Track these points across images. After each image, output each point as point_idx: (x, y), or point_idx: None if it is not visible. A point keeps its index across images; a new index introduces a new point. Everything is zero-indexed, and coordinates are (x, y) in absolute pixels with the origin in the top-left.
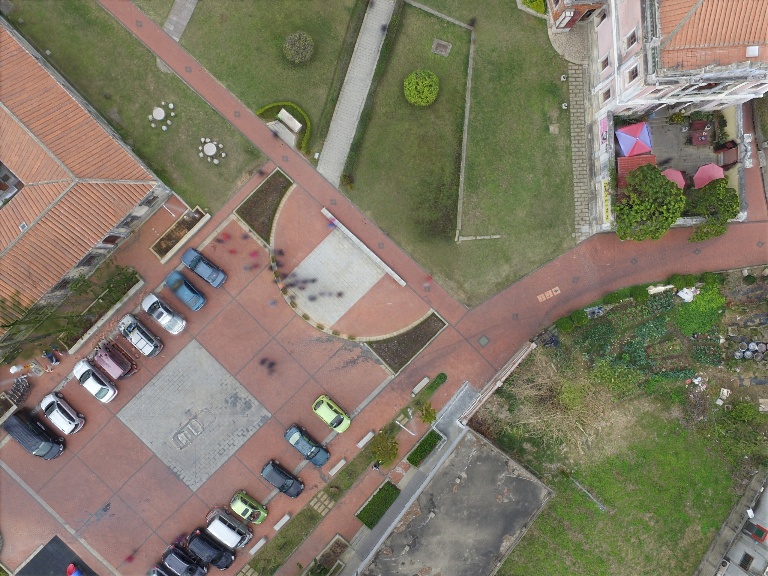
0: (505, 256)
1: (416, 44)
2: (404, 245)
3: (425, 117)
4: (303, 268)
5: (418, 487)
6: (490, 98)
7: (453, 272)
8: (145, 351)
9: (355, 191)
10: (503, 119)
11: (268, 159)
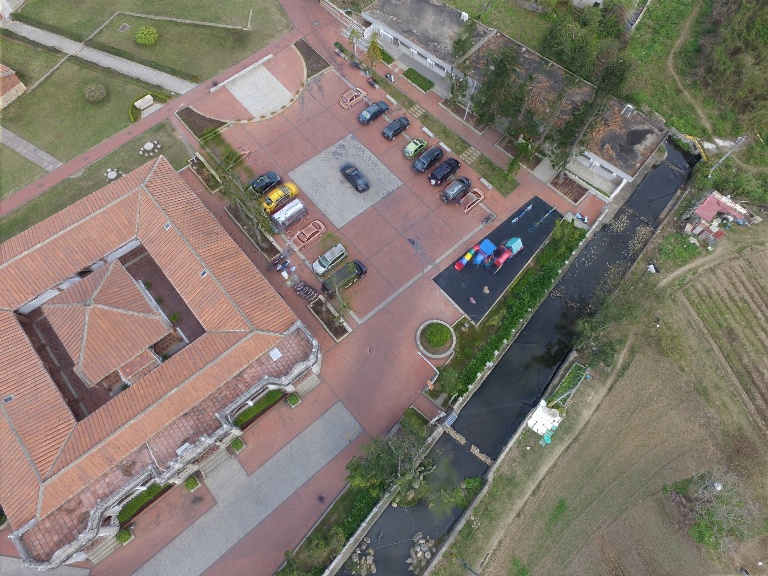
0: (264, 9)
1: (117, 39)
2: (246, 55)
3: (166, 39)
4: (249, 107)
5: (408, 60)
6: (164, 7)
7: (269, 34)
8: (288, 192)
9: (203, 76)
10: (179, 2)
11: (167, 119)
